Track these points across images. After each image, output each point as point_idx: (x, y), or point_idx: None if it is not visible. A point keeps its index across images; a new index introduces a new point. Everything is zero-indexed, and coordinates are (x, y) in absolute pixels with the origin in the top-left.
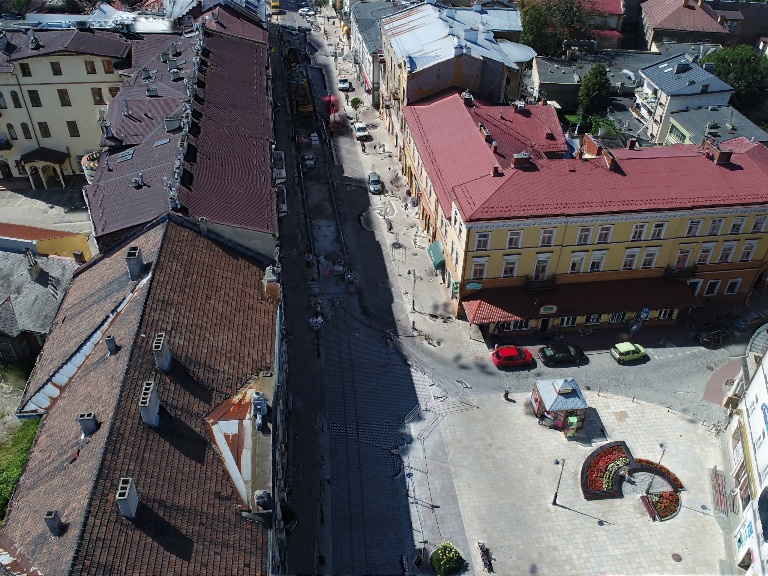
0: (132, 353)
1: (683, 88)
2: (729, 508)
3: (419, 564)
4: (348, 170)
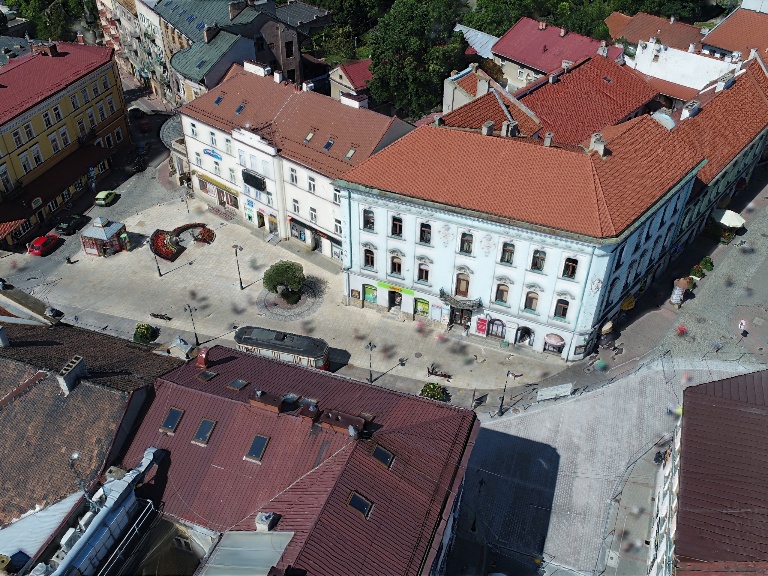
0: None
1: None
2: (231, 216)
3: None
4: None
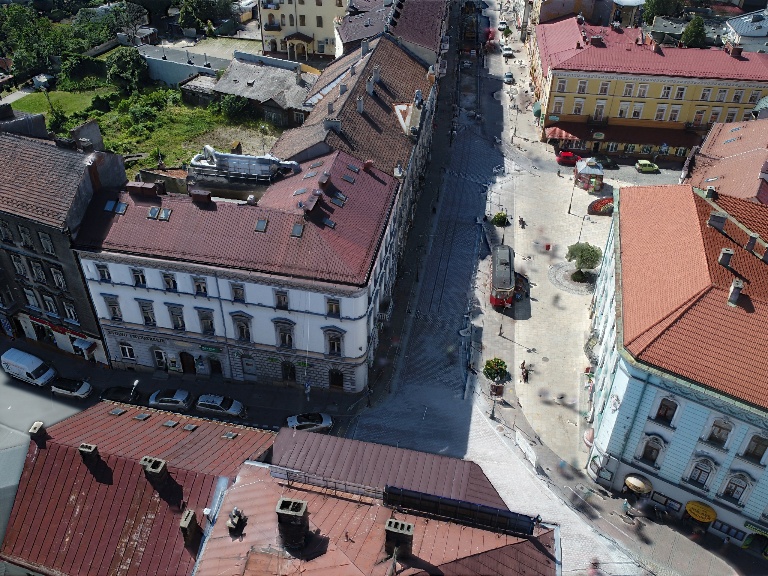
0: (363, 71)
1: (752, 31)
2: None
3: (485, 220)
4: (492, 71)
